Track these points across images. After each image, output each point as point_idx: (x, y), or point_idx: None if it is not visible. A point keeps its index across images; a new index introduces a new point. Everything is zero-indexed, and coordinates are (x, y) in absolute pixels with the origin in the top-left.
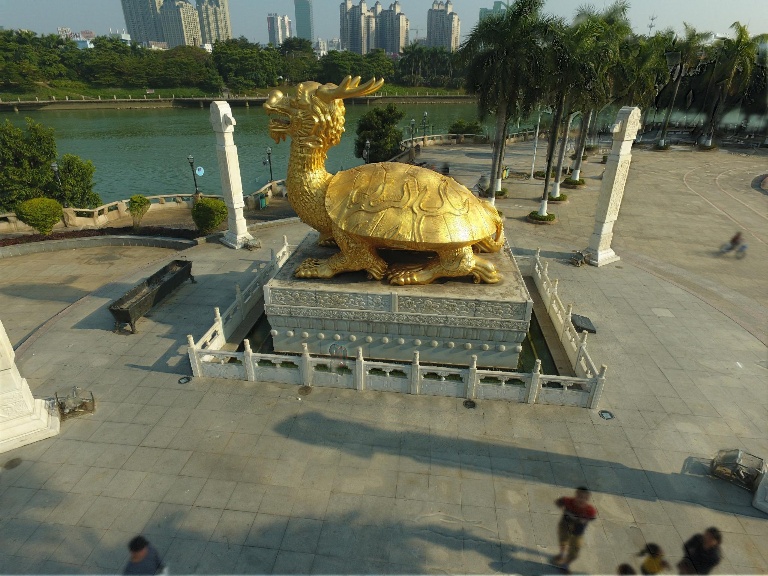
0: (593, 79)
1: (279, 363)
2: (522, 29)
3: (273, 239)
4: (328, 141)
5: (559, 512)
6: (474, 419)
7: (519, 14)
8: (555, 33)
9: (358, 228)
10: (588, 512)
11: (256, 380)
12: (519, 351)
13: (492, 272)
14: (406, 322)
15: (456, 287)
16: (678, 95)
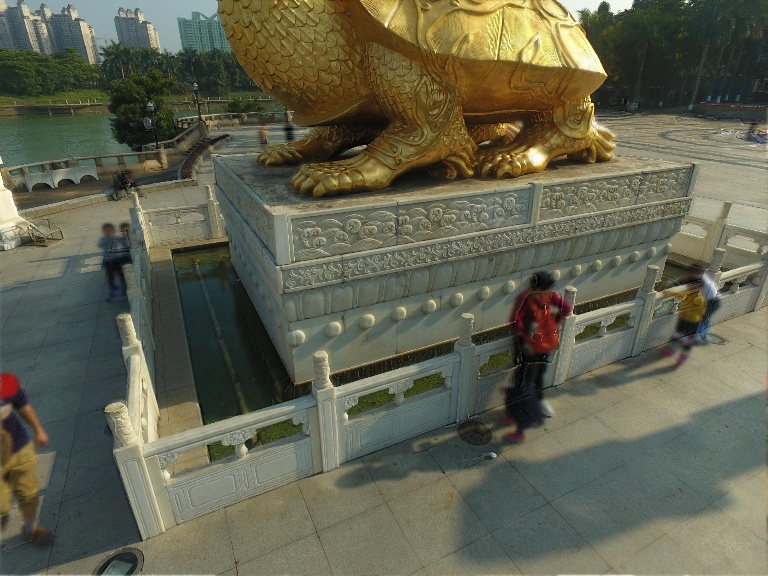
0: None
1: (406, 389)
2: None
3: (77, 226)
4: None
5: None
6: (758, 355)
7: None
8: None
9: (468, 45)
10: None
11: (343, 461)
12: None
13: None
14: (550, 238)
15: (583, 168)
16: None
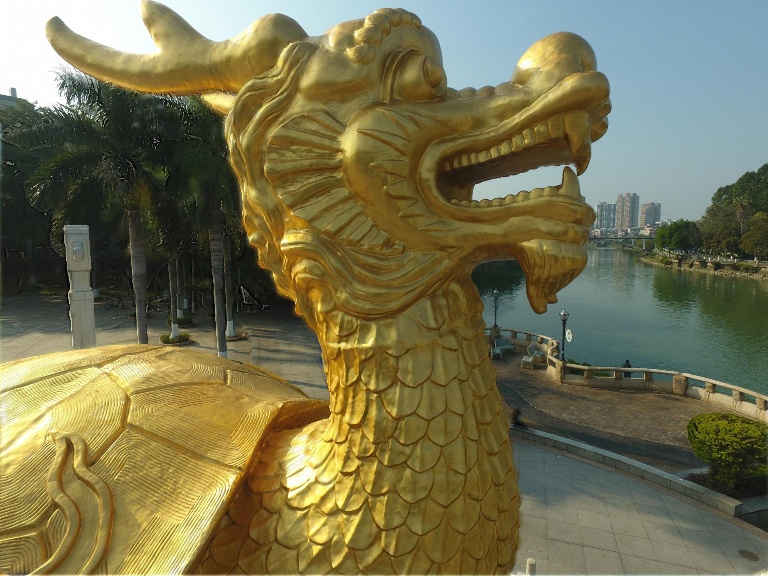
0: None
1: None
2: None
3: None
4: None
5: None
6: None
7: None
8: None
9: None
10: None
11: None
12: None
13: None
14: None
15: None
16: None
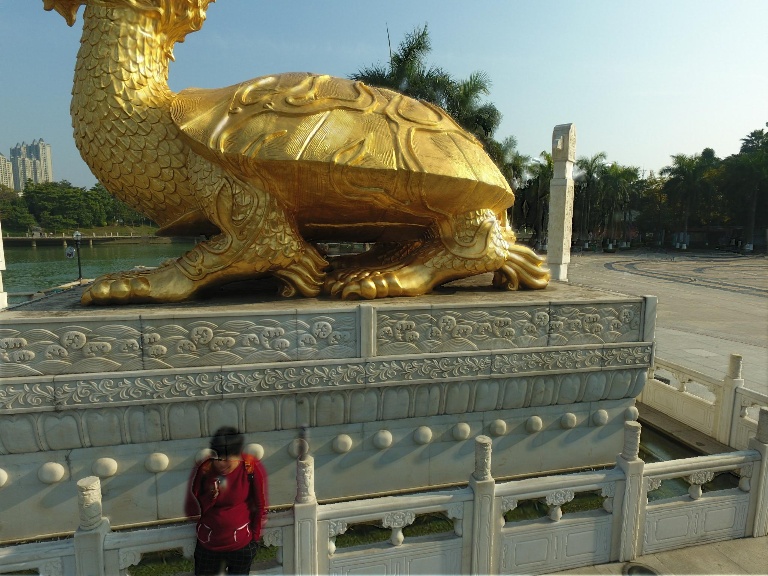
0: (495, 126)
1: None
2: (409, 79)
3: None
4: (176, 6)
5: None
6: None
7: (406, 59)
8: (445, 82)
9: (263, 144)
10: None
11: None
12: (635, 417)
13: (538, 264)
14: (398, 381)
15: (484, 295)
16: (515, 206)
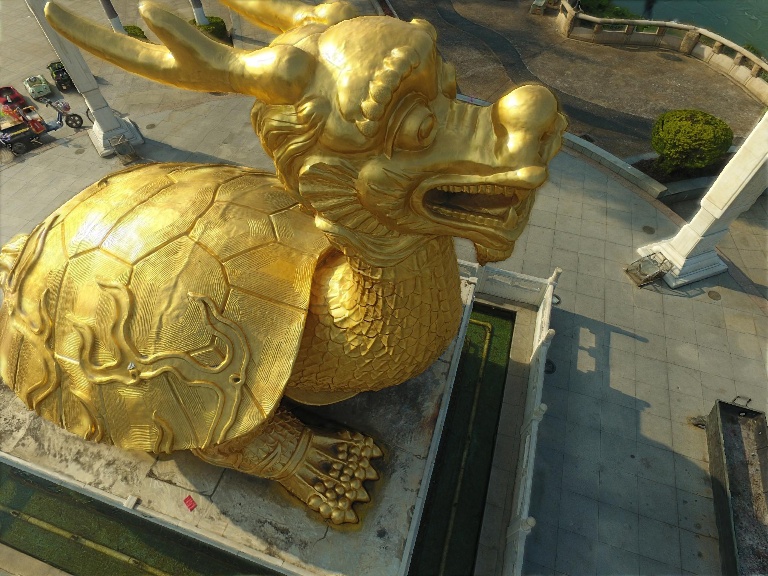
0: None
1: None
2: None
3: None
4: None
5: (260, 154)
6: None
7: None
8: None
9: None
10: (243, 152)
11: None
12: None
13: None
14: None
15: None
16: None
